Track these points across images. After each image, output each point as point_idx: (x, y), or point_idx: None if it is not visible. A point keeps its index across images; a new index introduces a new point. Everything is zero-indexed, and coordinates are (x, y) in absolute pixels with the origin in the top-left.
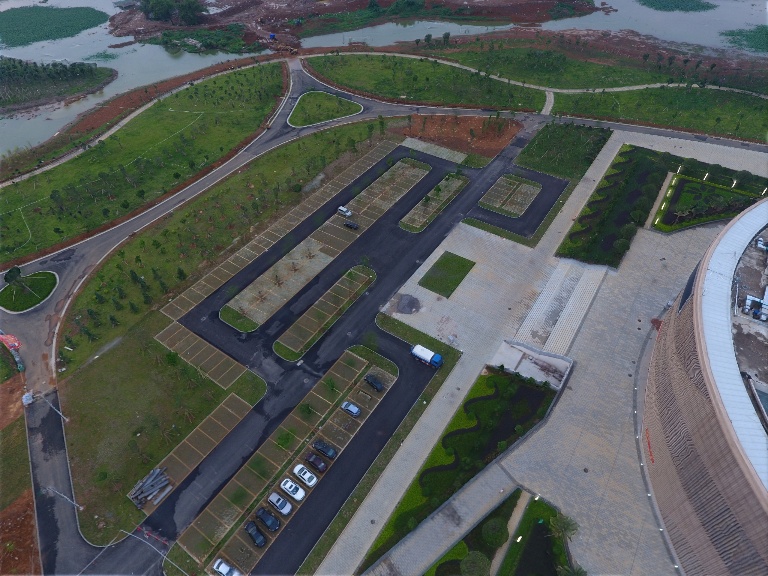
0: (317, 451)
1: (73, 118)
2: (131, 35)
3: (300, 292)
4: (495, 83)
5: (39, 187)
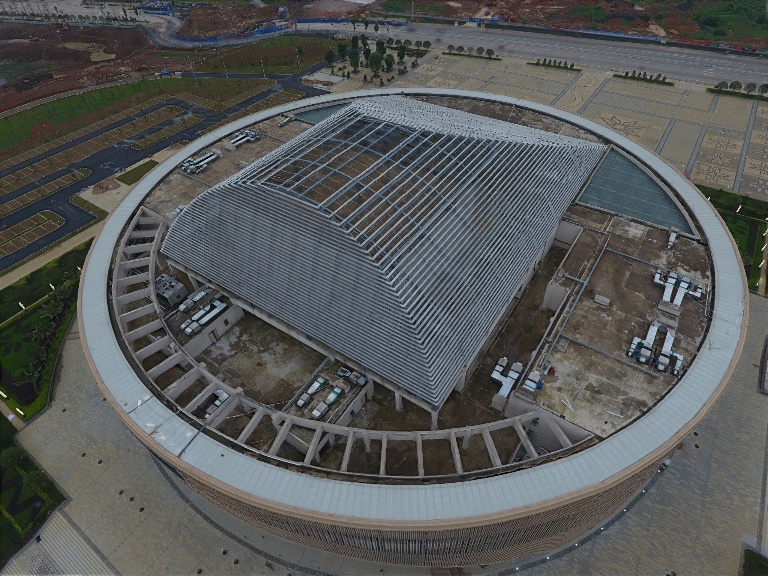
0: None
1: None
2: None
3: None
4: None
5: None
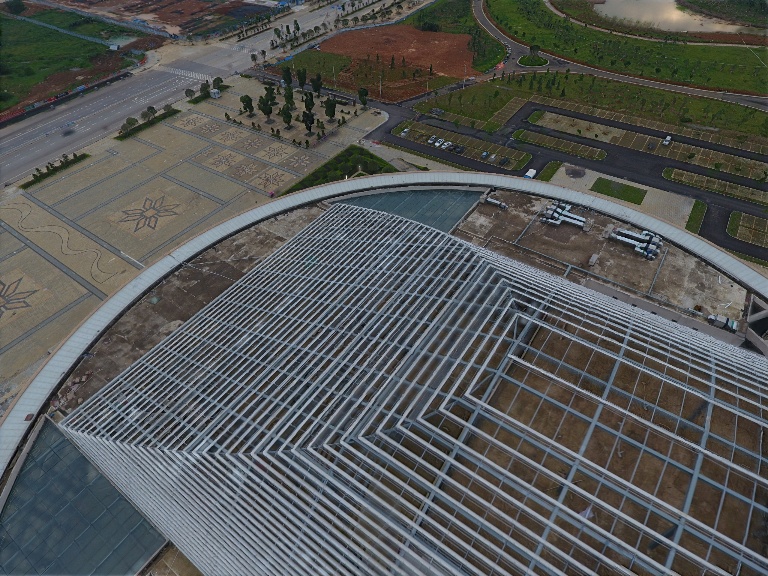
0: None
1: (711, 31)
2: None
3: (568, 133)
4: None
5: None
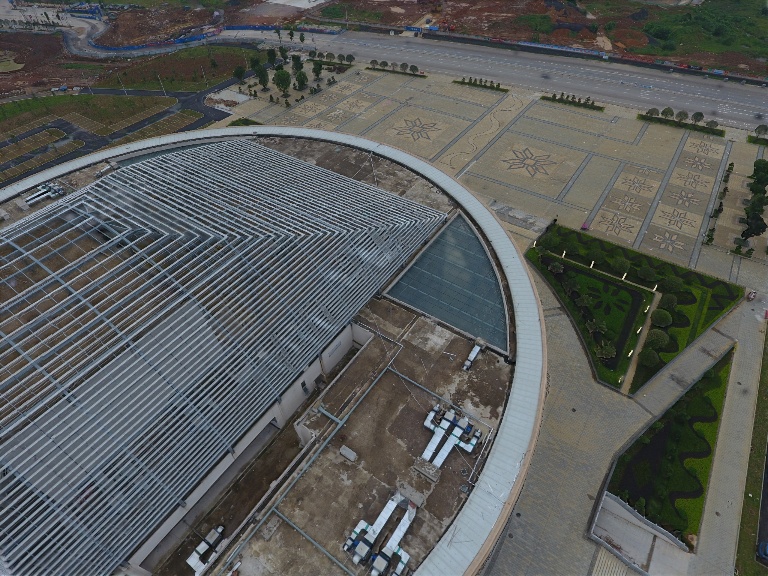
0: None
1: None
2: None
3: None
4: None
5: None
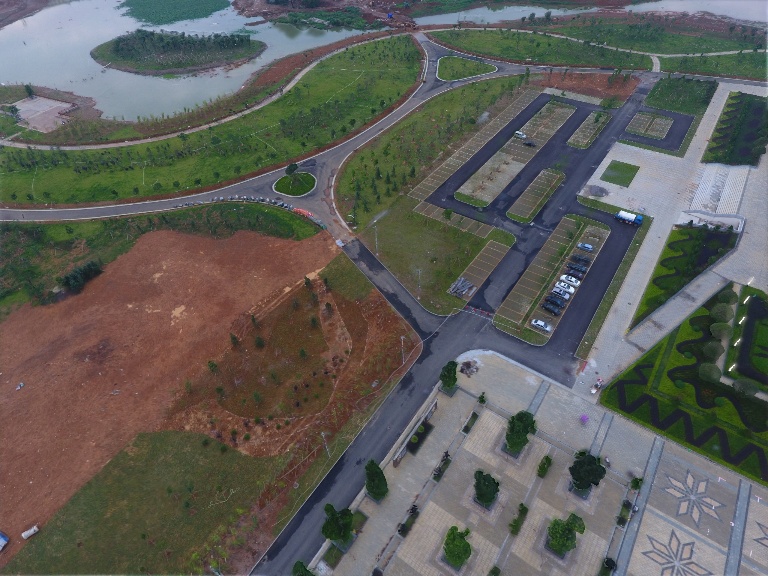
0: (571, 269)
1: (249, 76)
2: (259, 16)
3: (510, 184)
4: (604, 50)
5: (258, 121)
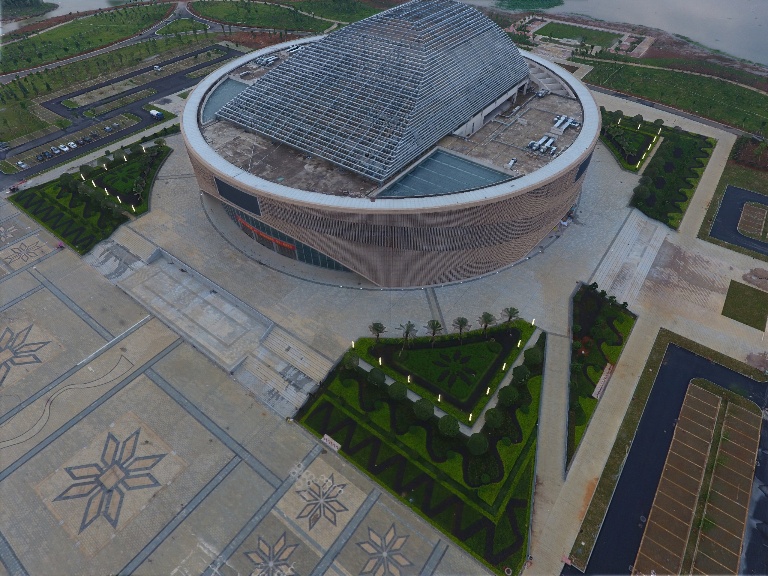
0: (83, 140)
1: (18, 28)
2: None
3: (111, 96)
4: None
5: None
